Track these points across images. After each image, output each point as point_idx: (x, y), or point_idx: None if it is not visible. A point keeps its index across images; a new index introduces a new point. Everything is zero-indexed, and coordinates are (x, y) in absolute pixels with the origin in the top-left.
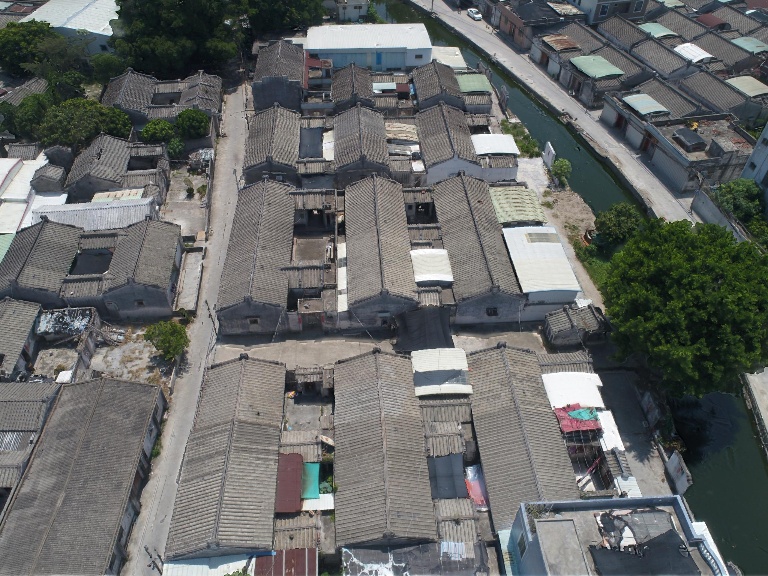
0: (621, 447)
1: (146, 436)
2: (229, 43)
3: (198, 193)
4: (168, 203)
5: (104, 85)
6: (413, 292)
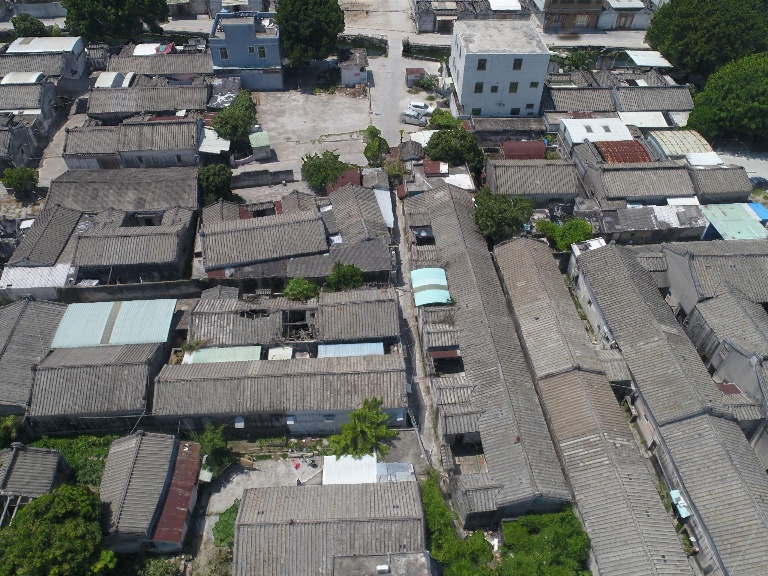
0: None
1: None
2: None
3: None
4: None
5: None
6: None
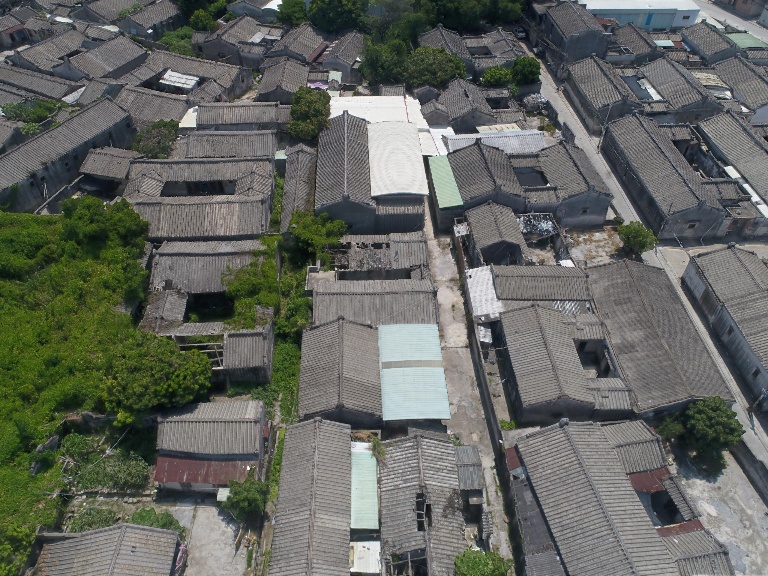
0: None
1: None
2: (514, 4)
3: (545, 131)
4: None
5: (410, 40)
6: None
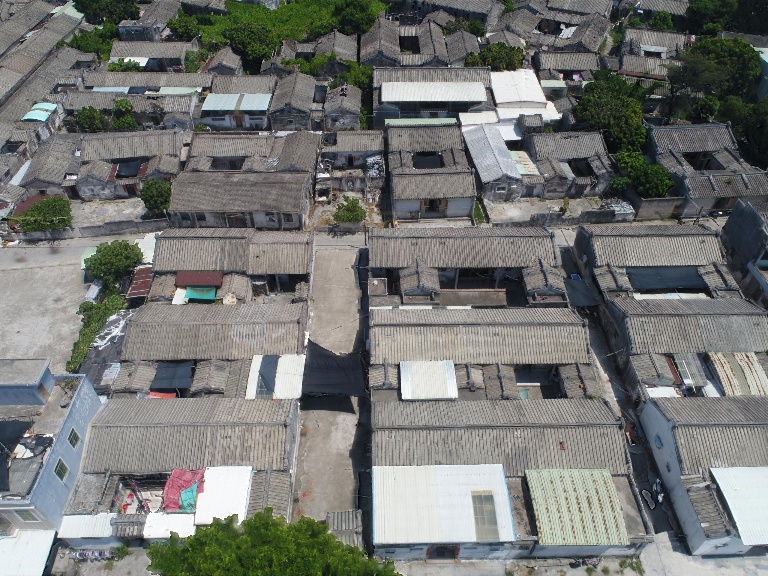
0: (148, 533)
1: (261, 213)
2: None
3: None
4: (545, 202)
5: None
6: (384, 358)
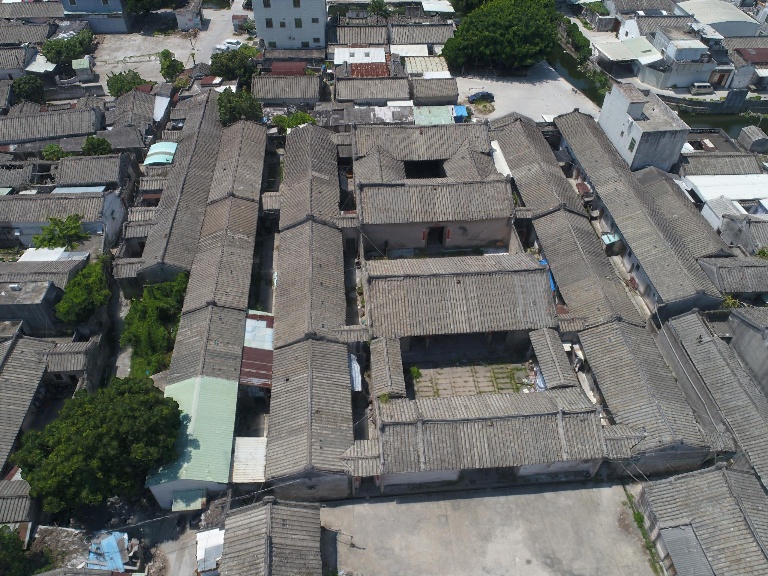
0: None
1: None
2: None
3: None
4: None
5: None
6: None
